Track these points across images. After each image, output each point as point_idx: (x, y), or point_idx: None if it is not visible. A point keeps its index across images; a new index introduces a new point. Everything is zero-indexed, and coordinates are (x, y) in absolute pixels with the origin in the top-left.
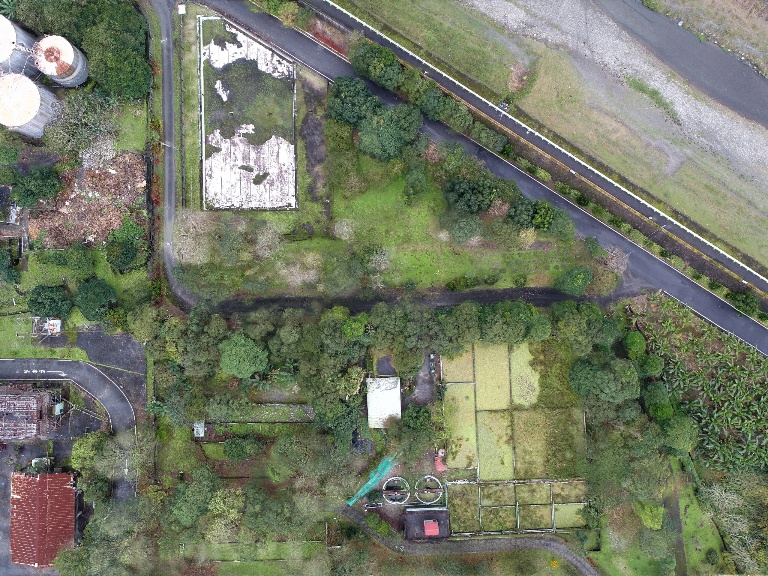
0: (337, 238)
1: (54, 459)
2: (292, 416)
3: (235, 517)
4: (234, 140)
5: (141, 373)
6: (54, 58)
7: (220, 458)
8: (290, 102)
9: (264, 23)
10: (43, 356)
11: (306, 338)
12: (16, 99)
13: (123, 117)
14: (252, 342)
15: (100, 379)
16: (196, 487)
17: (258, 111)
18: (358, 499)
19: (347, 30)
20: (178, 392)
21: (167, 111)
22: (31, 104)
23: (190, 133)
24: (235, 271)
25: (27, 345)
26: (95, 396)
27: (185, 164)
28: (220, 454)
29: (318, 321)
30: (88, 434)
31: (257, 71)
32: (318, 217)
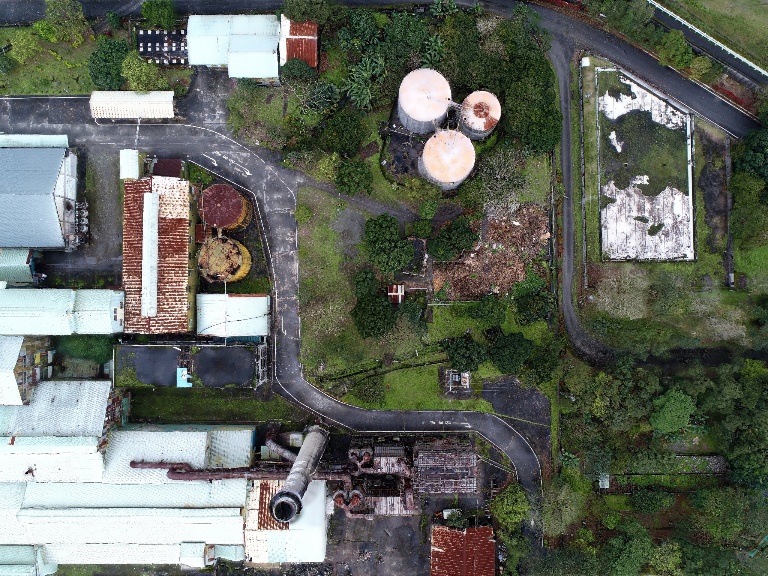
0: (742, 290)
1: (461, 511)
2: (694, 467)
3: (672, 573)
4: (629, 191)
5: (546, 425)
6: (484, 114)
7: (622, 509)
8: (684, 153)
9: (661, 75)
10: (449, 408)
11: (750, 395)
12: (454, 155)
13: (525, 169)
14: (689, 398)
15: (505, 431)
16: (638, 543)
17: (652, 162)
18: (759, 550)
19: (751, 83)
20: (598, 445)
21: (565, 163)
22: (467, 160)
23: (589, 185)
24: (635, 322)
25: (433, 397)
26: (501, 448)
27: (584, 215)
28: (622, 505)
29: (738, 375)
30: (511, 488)
31: (651, 122)
32: (717, 268)
